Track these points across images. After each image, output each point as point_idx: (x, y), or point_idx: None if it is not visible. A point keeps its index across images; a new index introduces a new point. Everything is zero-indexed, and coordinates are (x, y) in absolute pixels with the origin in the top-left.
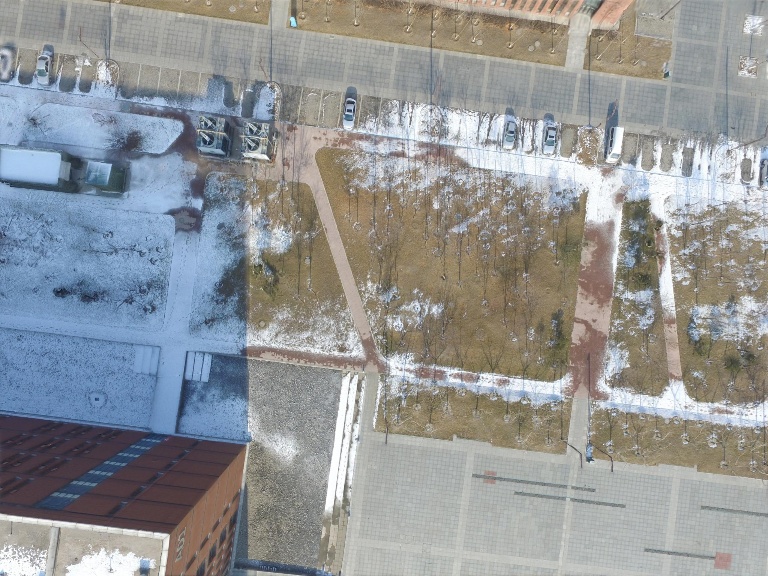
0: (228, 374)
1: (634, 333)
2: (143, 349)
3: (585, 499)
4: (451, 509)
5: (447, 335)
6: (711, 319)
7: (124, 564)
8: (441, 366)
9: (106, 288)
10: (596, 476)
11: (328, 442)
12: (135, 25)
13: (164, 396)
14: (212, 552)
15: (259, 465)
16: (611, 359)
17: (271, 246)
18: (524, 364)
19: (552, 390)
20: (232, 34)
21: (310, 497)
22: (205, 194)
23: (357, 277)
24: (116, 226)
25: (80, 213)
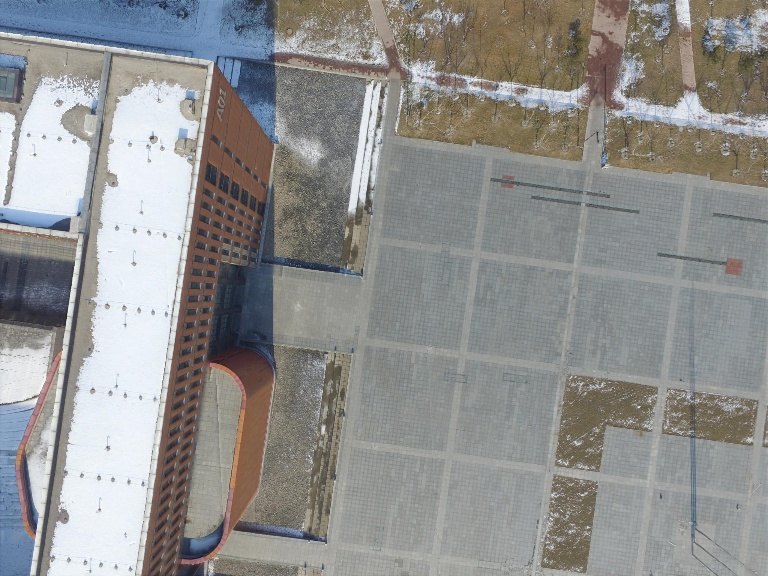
0: (256, 80)
1: (650, 44)
2: None
3: (600, 204)
4: (470, 211)
5: (468, 43)
6: (726, 31)
7: (171, 94)
8: (461, 74)
9: None
10: (611, 183)
11: (352, 147)
12: None
13: None
14: (244, 200)
15: (285, 168)
16: (627, 70)
17: None
18: (542, 73)
19: (569, 99)
20: None
21: (334, 199)
22: None
23: None
24: None
25: None
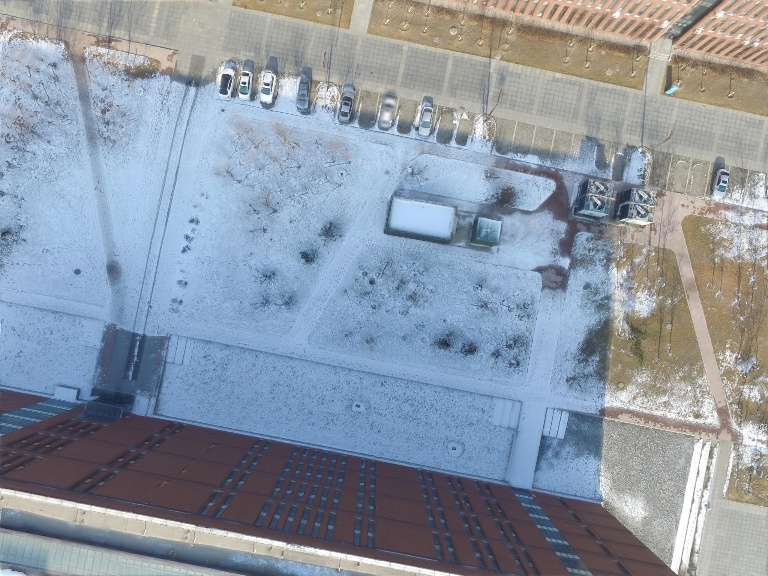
0: (583, 432)
1: None
2: (503, 402)
3: None
4: None
5: None
6: None
7: None
8: None
9: (474, 340)
10: None
11: (676, 506)
12: (513, 82)
13: (523, 451)
14: None
15: None
16: None
17: (635, 309)
18: None
19: None
20: (607, 97)
21: None
22: (573, 254)
23: (716, 345)
24: (485, 280)
25: (450, 264)
